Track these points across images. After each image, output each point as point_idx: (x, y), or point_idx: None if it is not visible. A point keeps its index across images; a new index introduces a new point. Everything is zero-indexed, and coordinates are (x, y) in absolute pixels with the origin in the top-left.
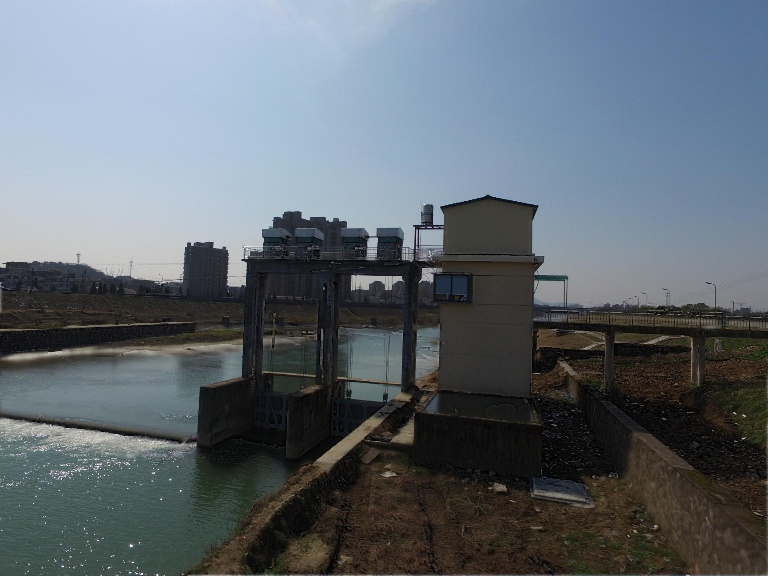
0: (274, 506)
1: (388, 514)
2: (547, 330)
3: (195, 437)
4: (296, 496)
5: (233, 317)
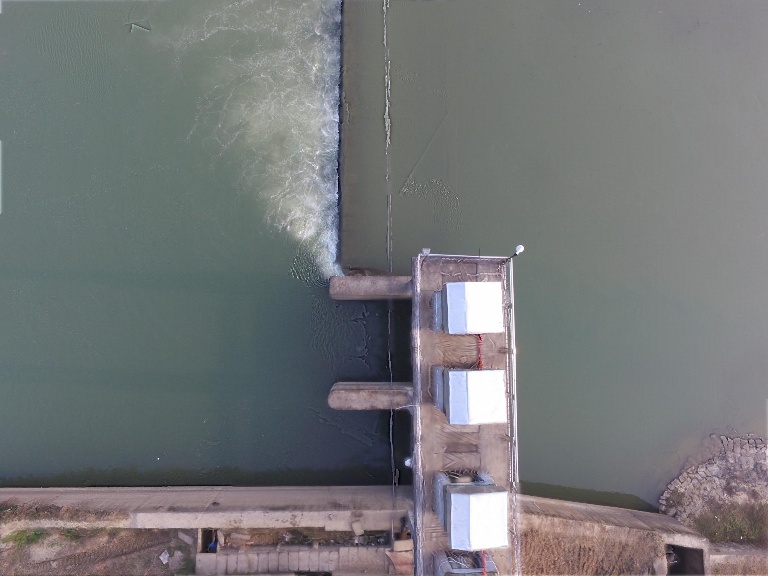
0: (58, 524)
1: (100, 575)
2: None
3: (345, 272)
4: (75, 528)
5: None
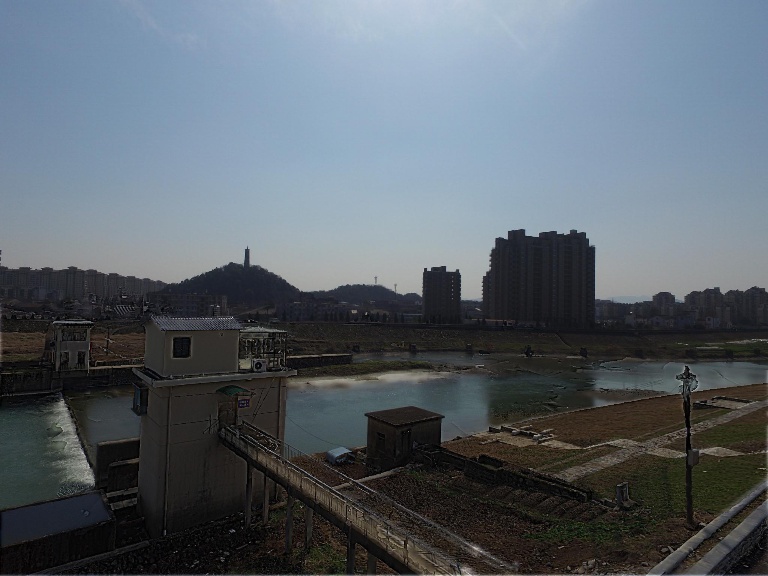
0: None
1: None
2: (761, 389)
3: None
4: None
5: (424, 344)
